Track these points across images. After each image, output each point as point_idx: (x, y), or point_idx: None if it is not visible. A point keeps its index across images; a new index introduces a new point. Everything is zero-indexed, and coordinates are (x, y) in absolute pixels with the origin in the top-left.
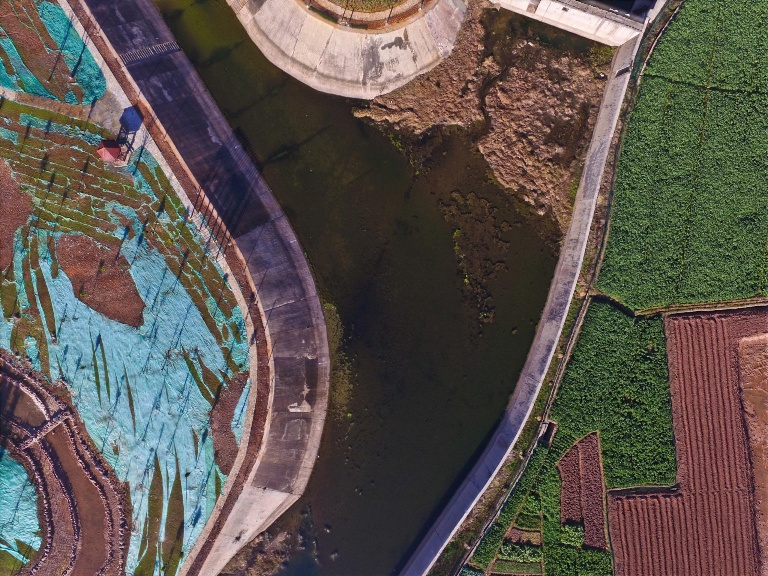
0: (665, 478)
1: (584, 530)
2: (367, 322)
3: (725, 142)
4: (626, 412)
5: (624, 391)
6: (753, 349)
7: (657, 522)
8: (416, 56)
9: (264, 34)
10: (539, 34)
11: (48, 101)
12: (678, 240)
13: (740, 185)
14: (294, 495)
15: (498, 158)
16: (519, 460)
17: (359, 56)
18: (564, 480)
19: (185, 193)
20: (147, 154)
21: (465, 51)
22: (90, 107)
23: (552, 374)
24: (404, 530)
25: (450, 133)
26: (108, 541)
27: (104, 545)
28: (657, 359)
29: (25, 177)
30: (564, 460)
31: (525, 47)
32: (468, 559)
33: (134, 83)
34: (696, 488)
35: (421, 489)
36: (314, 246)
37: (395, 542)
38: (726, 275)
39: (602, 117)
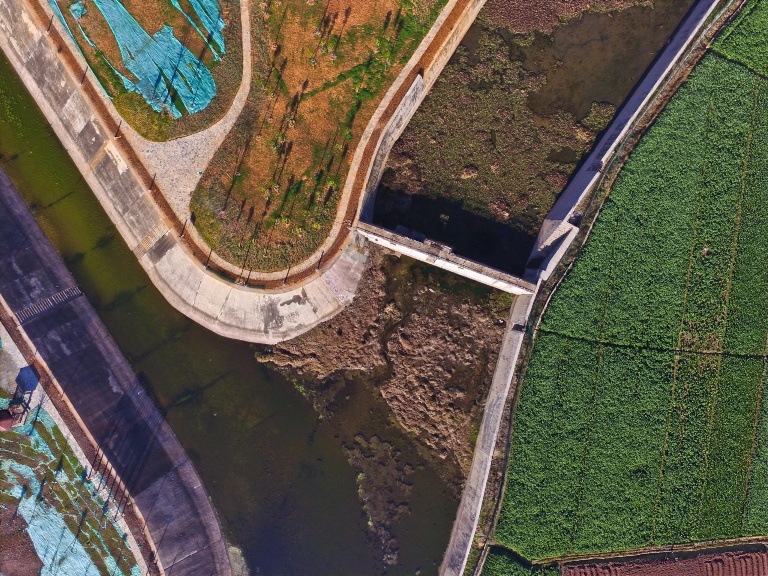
0: None
1: None
2: (272, 564)
3: (617, 397)
4: None
5: None
6: None
7: None
8: (316, 308)
9: (165, 283)
10: (440, 280)
11: None
12: (573, 492)
13: (632, 439)
14: None
15: (400, 403)
16: None
17: (259, 311)
18: None
19: (83, 453)
20: (44, 413)
21: (366, 299)
22: None
23: None
24: None
25: (353, 377)
26: None
27: None
28: None
29: None
30: None
31: (426, 293)
32: None
33: (30, 342)
34: None
35: None
36: (219, 489)
37: None
38: (619, 527)
39: (500, 367)
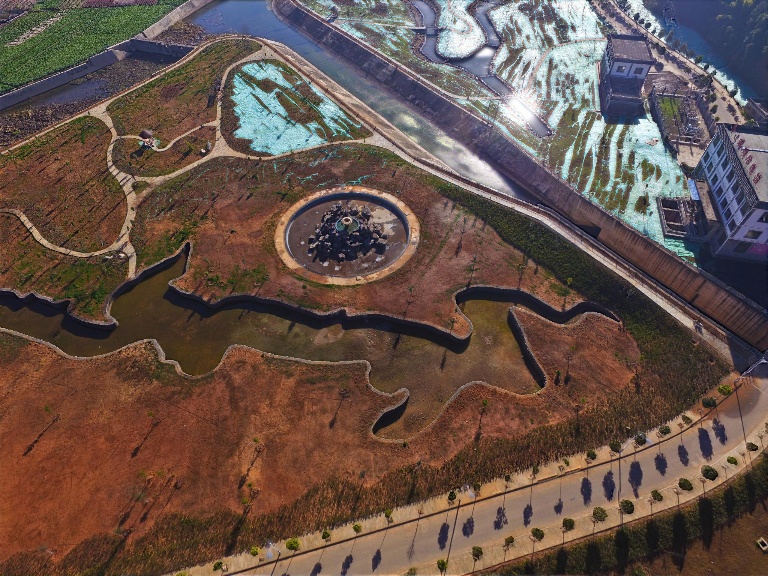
0: None
1: None
2: None
3: None
4: None
5: None
6: None
7: None
8: None
9: None
10: None
11: None
12: None
13: None
14: None
15: None
16: None
17: None
18: None
19: None
20: None
21: None
22: (346, 22)
23: None
24: None
25: None
26: None
27: None
28: None
29: None
30: None
31: None
32: None
33: None
34: None
35: None
36: None
37: None
38: (131, 8)
39: None
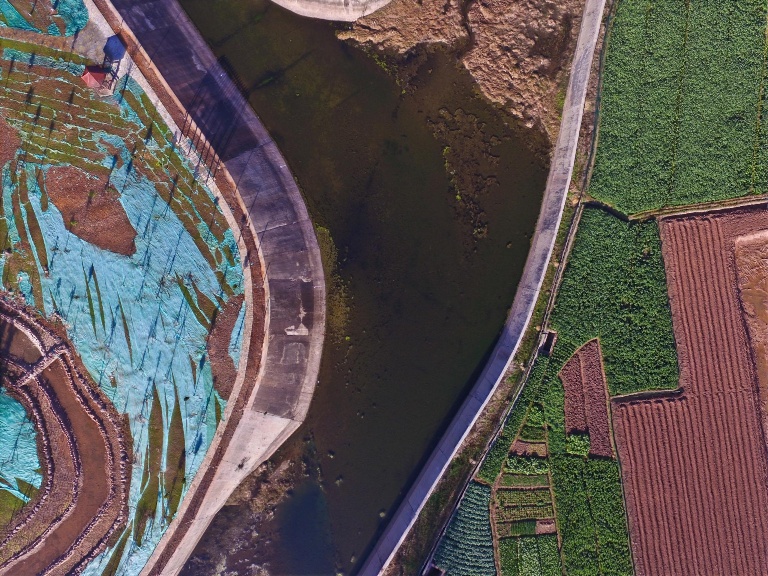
0: (668, 382)
1: (589, 439)
2: (361, 244)
3: (709, 42)
4: (625, 317)
5: (622, 296)
6: (749, 249)
7: (662, 427)
8: None
9: None
10: None
11: (31, 34)
12: (668, 142)
13: (726, 83)
14: (295, 421)
15: (484, 73)
16: (520, 371)
17: None
18: (567, 389)
19: (172, 119)
20: (132, 82)
21: None
22: (73, 38)
23: (549, 283)
24: (408, 452)
25: (435, 51)
26: (109, 476)
27: (105, 480)
28: (653, 262)
29: (11, 111)
30: (565, 369)
31: None
32: (474, 475)
33: (116, 12)
34: (700, 390)
35: (423, 410)
36: (304, 170)
37: (400, 465)
38: (718, 174)
39: (585, 25)
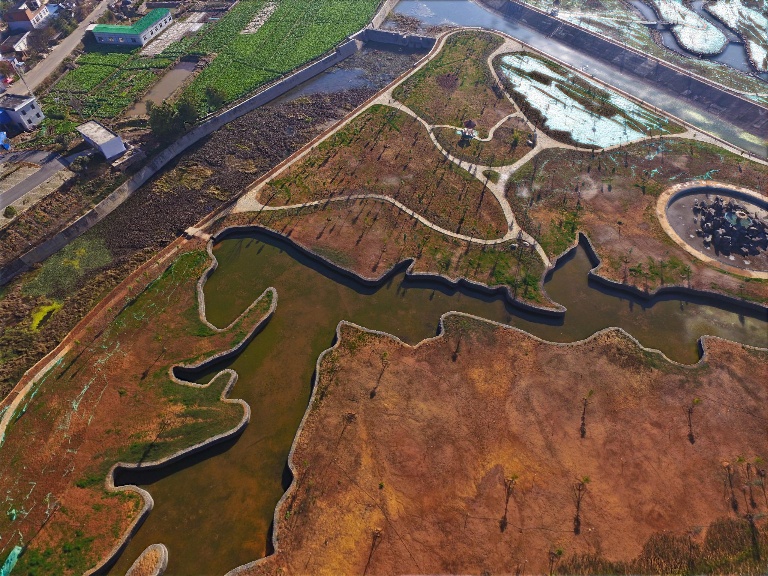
0: None
1: None
2: None
3: None
4: None
5: None
6: None
7: None
8: None
9: None
10: None
11: None
12: None
13: None
14: None
15: None
16: None
17: None
18: None
19: None
20: None
21: None
22: None
23: None
24: None
25: (435, 25)
26: None
27: None
28: None
29: None
30: None
31: None
32: None
33: None
34: None
35: None
36: None
37: None
38: None
39: None
